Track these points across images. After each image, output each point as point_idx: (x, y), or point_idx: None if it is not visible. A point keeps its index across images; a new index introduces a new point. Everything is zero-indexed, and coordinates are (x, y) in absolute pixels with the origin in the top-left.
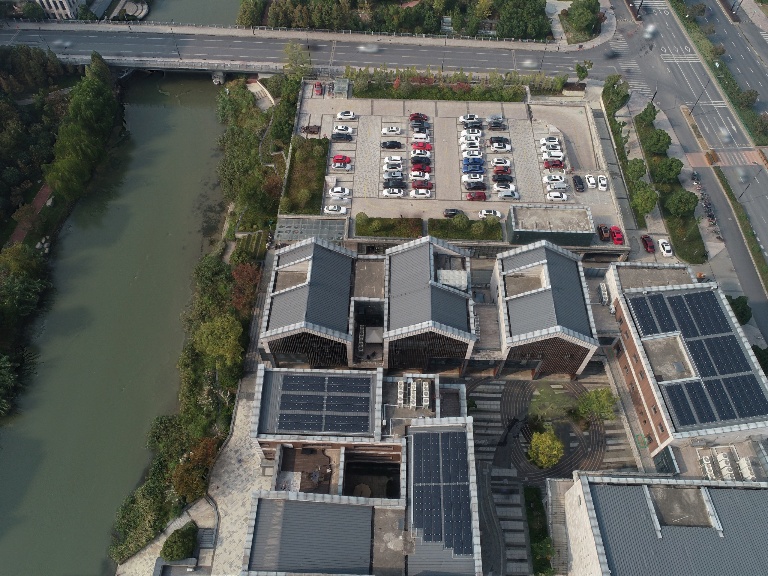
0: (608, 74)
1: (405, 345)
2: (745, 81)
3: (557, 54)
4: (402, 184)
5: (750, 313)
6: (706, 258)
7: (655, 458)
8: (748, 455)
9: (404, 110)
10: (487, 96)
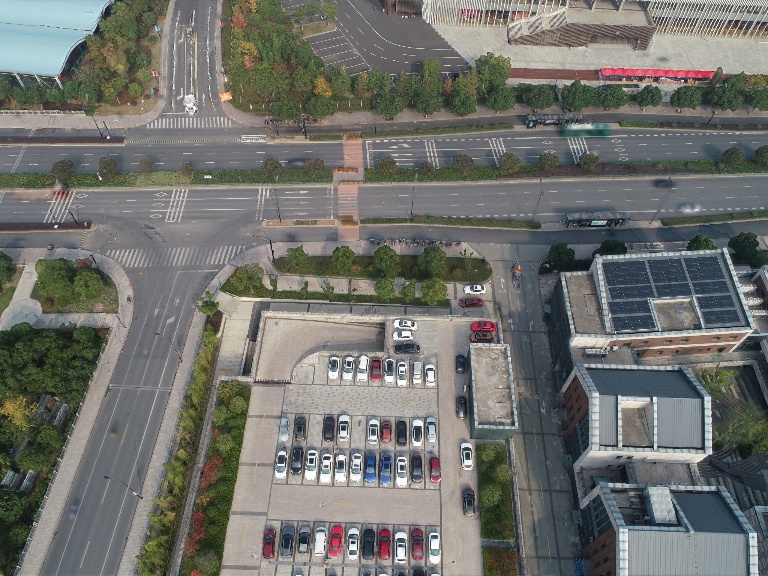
0: (192, 281)
1: None
2: (229, 163)
3: (135, 331)
4: (421, 575)
5: None
6: (485, 261)
7: None
8: None
9: (245, 568)
10: (236, 434)
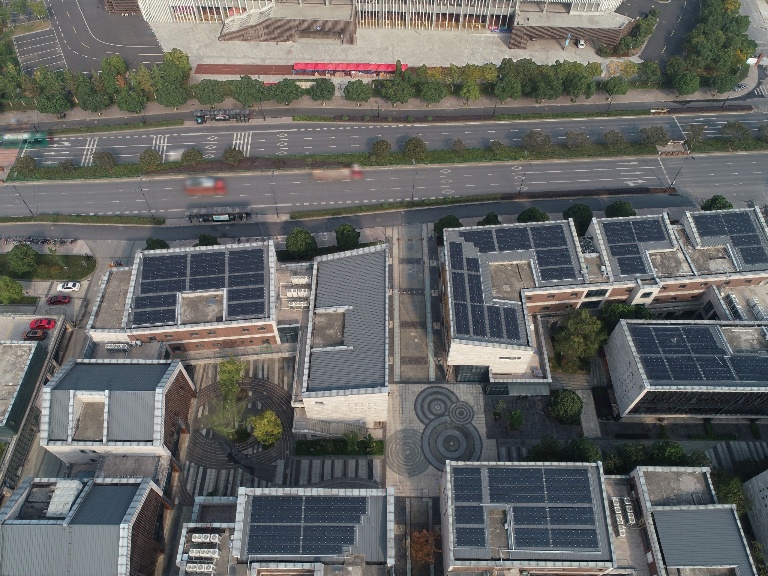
0: None
1: (136, 565)
2: None
3: None
4: None
5: (162, 241)
6: (91, 258)
7: (282, 341)
8: (288, 276)
9: None
10: None
